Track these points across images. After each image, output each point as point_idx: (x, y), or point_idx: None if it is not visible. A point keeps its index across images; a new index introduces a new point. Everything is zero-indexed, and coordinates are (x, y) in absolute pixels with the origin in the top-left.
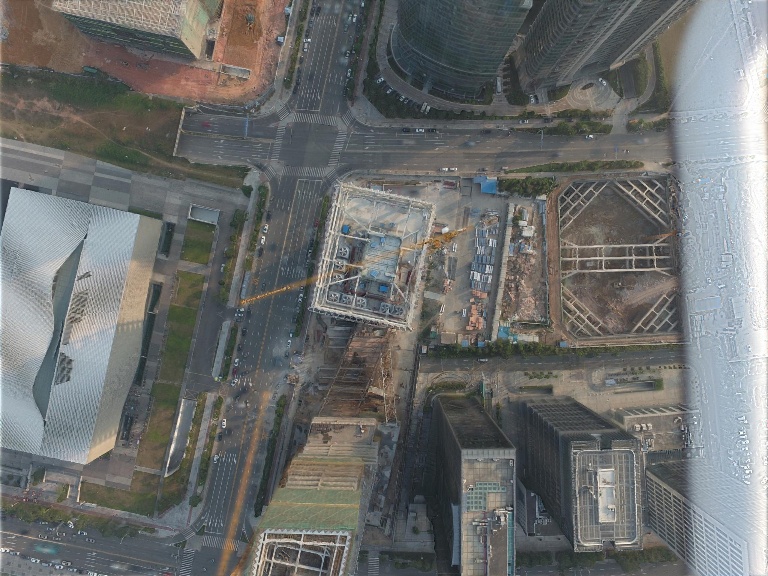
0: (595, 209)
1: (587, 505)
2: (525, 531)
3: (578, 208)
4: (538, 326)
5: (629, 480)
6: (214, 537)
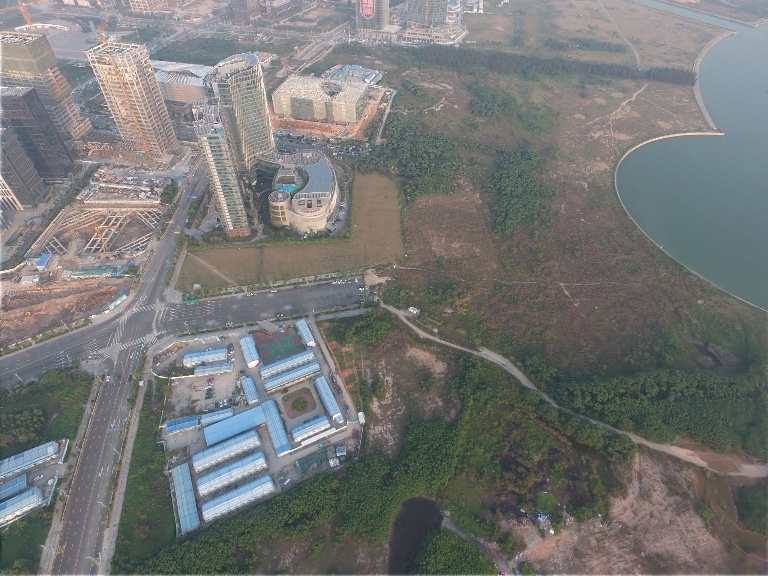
0: None
1: None
2: None
3: None
4: None
5: None
6: None
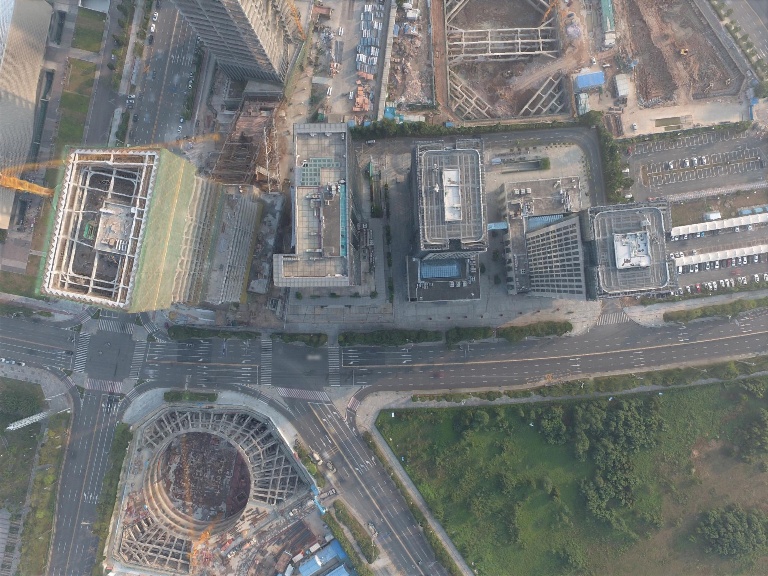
0: (486, 5)
1: (434, 205)
2: (408, 297)
3: None
4: (425, 108)
5: (475, 181)
6: (109, 321)
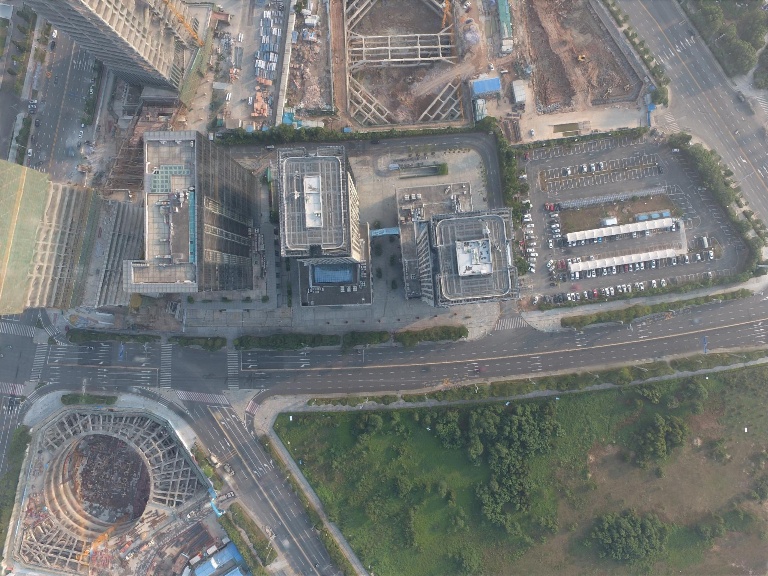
0: (391, 10)
1: (295, 212)
2: (300, 302)
3: (364, 0)
4: (323, 113)
5: (336, 187)
6: (11, 324)
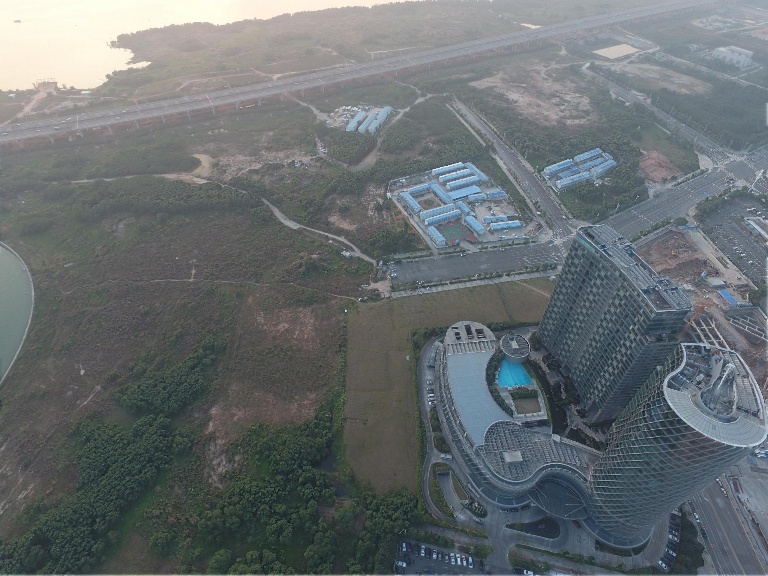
0: None
1: None
2: None
3: None
4: None
5: None
6: None
